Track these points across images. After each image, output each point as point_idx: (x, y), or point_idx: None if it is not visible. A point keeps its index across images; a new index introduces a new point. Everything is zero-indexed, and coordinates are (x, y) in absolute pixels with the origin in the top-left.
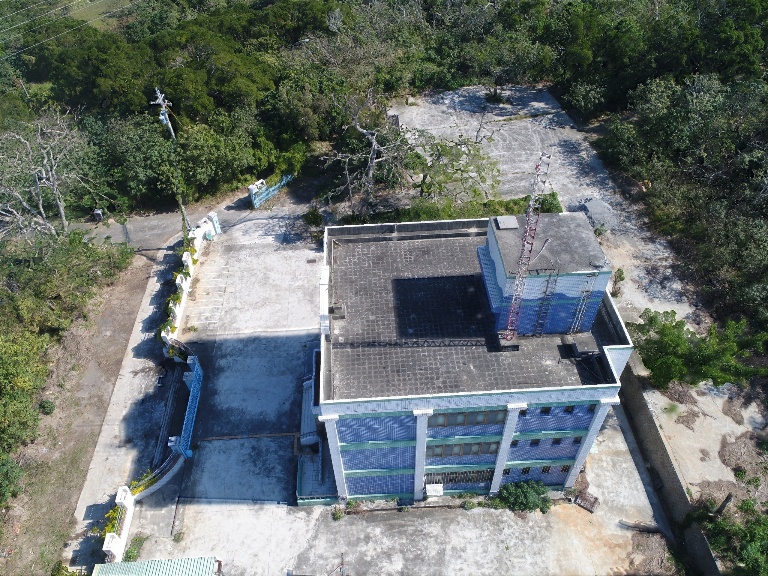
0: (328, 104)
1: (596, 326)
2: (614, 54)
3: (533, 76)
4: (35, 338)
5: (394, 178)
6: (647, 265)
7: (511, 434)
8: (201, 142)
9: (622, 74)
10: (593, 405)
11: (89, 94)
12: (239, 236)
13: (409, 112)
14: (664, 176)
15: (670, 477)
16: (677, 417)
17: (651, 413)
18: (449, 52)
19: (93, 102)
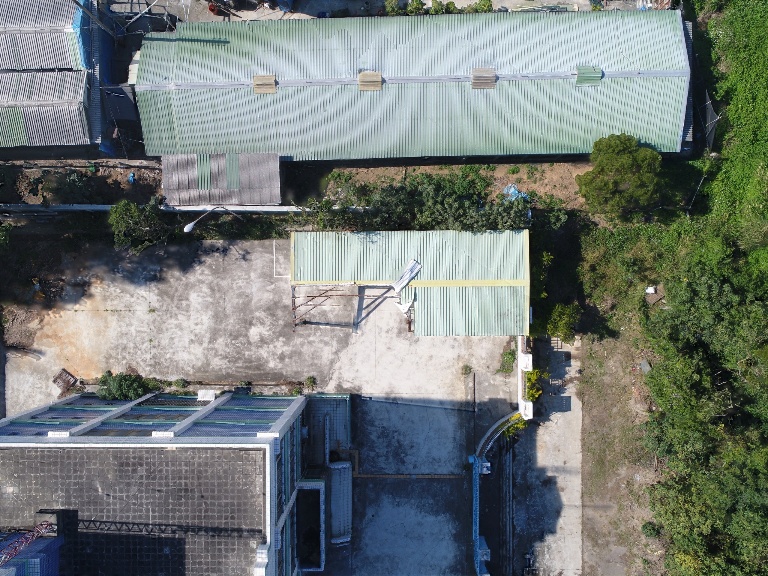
0: None
1: None
2: None
3: None
4: None
5: None
6: None
7: None
8: None
9: None
10: None
11: None
12: None
13: None
14: None
15: None
16: None
17: None
18: None
19: None
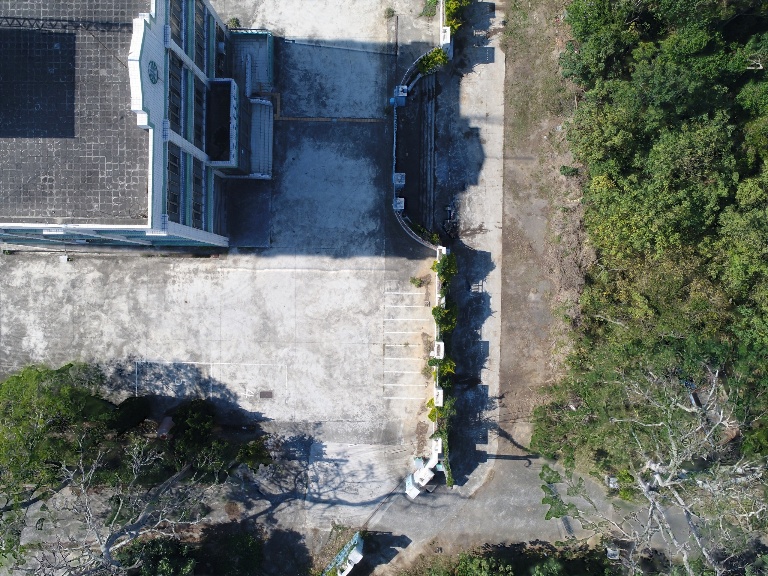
0: None
1: None
2: None
3: None
4: None
5: None
6: None
7: None
8: None
9: None
10: None
11: None
12: (377, 465)
13: None
14: None
15: None
16: None
17: None
18: None
19: None
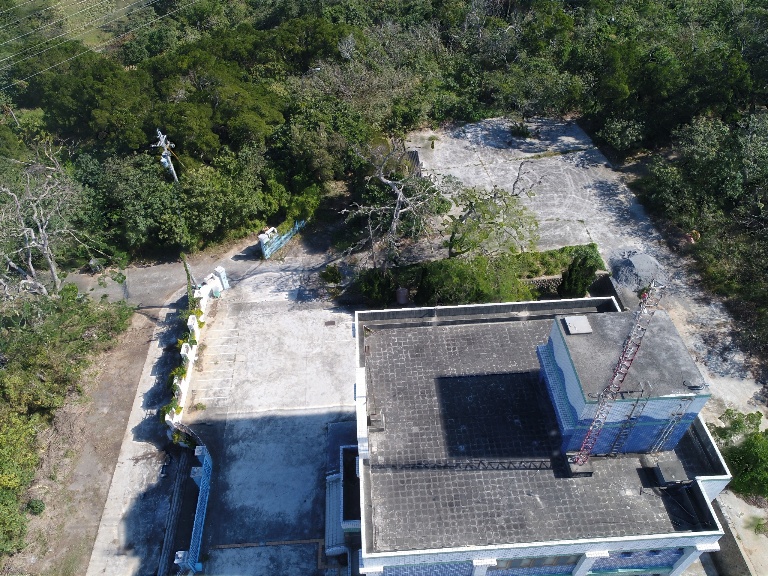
0: (344, 142)
1: (679, 442)
2: (651, 87)
3: (560, 107)
4: (23, 422)
5: (417, 225)
6: (704, 332)
7: (583, 575)
8: (207, 188)
9: (660, 109)
10: None
11: (84, 123)
12: (249, 292)
13: (429, 147)
14: (718, 230)
15: None
16: (756, 525)
17: (726, 520)
18: (469, 80)
19: (88, 132)
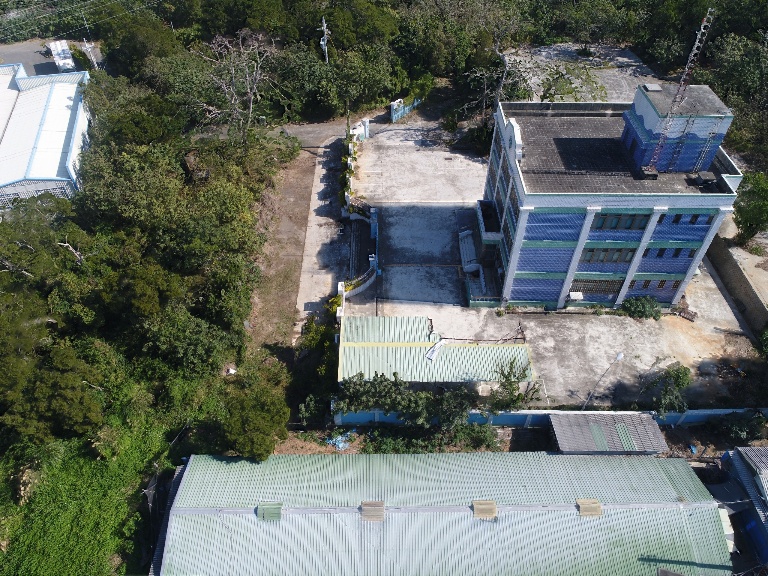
0: None
1: (711, 170)
2: (692, 18)
3: (616, 38)
4: None
5: None
6: None
7: (648, 240)
8: (355, 64)
9: None
10: (711, 218)
11: None
12: (384, 140)
13: None
14: (739, 105)
15: (752, 301)
16: (756, 264)
17: (736, 261)
18: (542, 16)
19: None
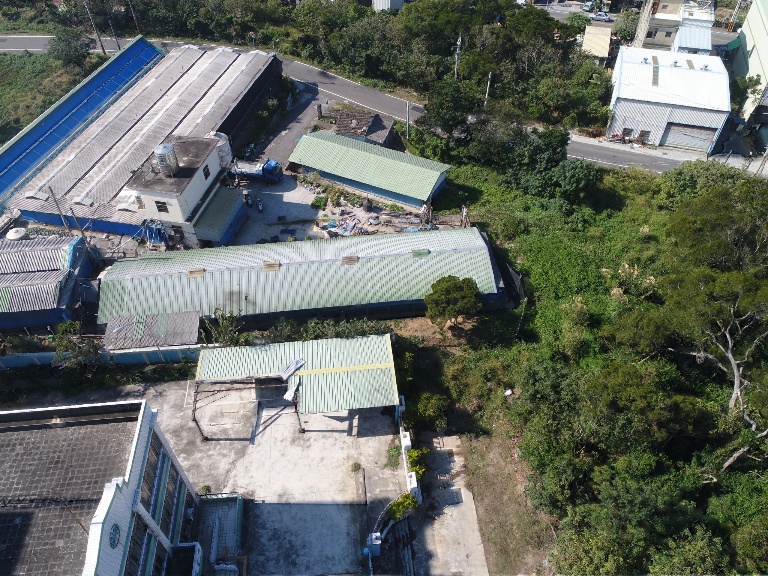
0: None
1: None
2: None
3: None
4: None
5: None
6: None
7: None
8: None
9: None
10: None
11: None
12: None
13: None
14: None
15: None
16: None
17: None
18: None
19: None
